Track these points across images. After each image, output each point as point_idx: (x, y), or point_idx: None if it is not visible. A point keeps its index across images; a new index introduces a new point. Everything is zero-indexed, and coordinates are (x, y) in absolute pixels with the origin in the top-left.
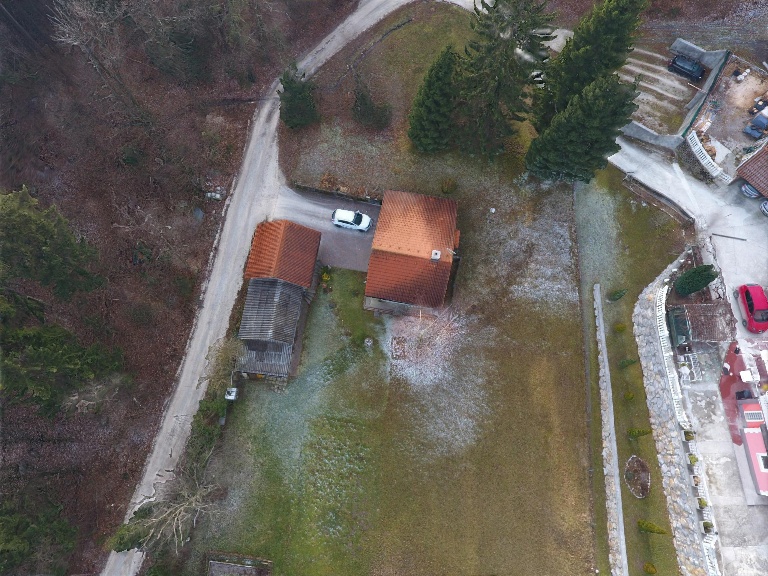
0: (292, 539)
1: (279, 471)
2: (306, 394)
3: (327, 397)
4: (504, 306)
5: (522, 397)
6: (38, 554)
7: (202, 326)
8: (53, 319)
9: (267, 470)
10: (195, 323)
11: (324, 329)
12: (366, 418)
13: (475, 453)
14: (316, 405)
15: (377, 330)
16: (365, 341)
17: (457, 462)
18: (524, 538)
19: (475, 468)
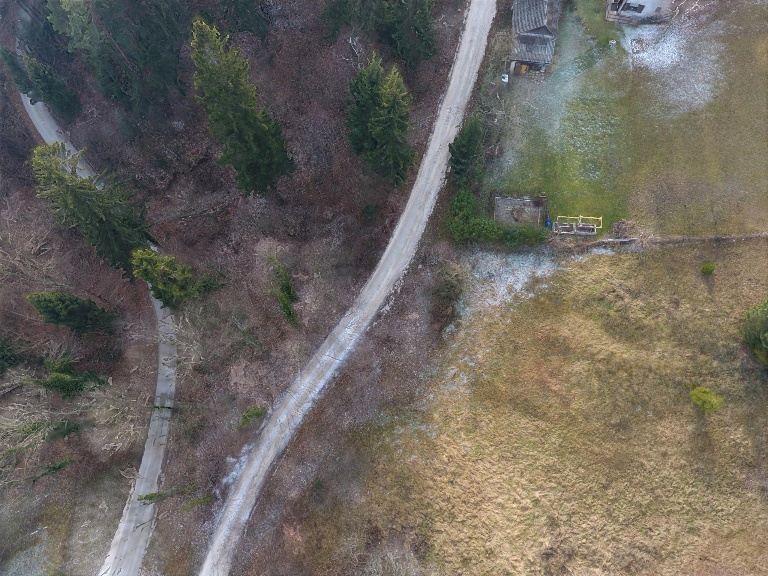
0: (560, 182)
1: (543, 138)
2: (561, 84)
3: (579, 85)
4: (728, 6)
5: (751, 63)
6: (413, 132)
7: (465, 44)
8: (341, 40)
9: (533, 138)
10: (460, 41)
11: (572, 38)
12: (613, 97)
13: (713, 106)
14: (570, 91)
15: (618, 35)
16: (609, 42)
17: (698, 114)
18: (763, 152)
19: (715, 115)
